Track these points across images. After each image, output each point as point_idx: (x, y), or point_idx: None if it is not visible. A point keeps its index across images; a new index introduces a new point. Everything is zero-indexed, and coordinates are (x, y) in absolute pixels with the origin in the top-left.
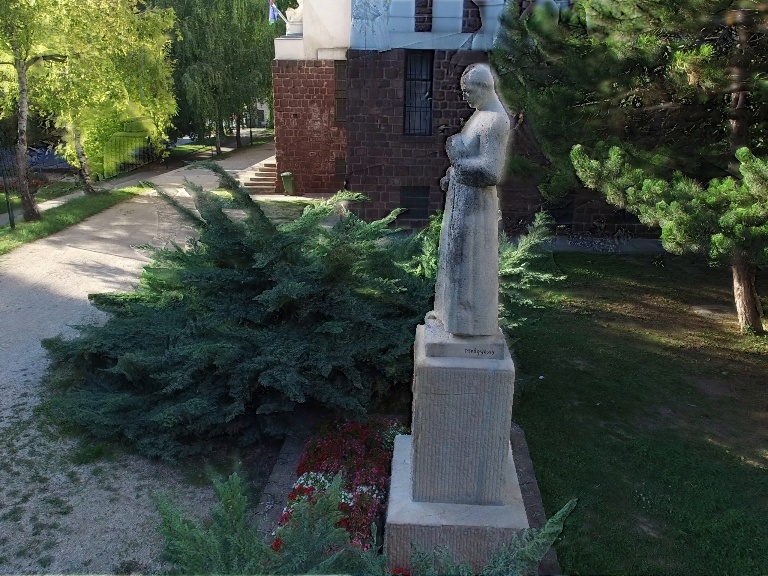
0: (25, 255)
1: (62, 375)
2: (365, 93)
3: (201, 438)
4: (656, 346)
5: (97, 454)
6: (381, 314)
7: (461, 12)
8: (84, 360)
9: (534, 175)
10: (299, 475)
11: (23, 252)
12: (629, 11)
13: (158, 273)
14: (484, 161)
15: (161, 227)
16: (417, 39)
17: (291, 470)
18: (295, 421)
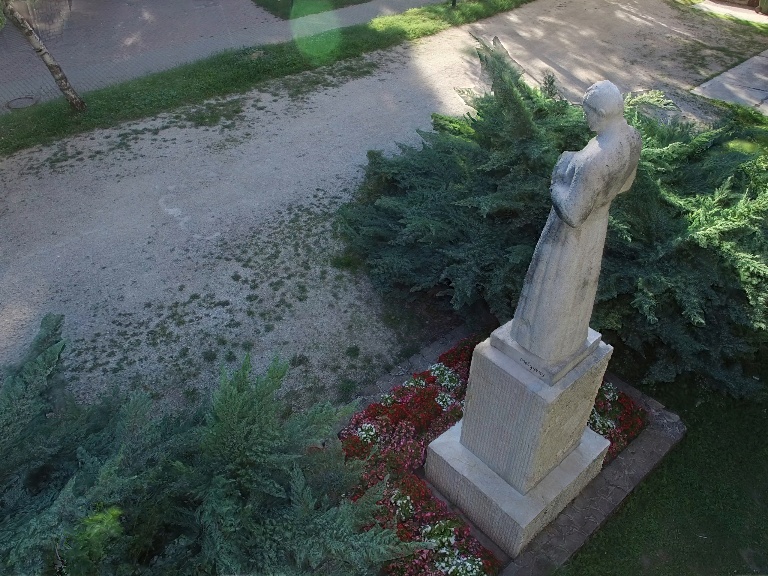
0: (444, 41)
1: (364, 187)
2: None
3: None
4: None
5: (347, 264)
6: (612, 249)
7: None
8: (383, 181)
9: None
10: (438, 361)
11: (444, 37)
12: None
13: (427, 138)
14: (565, 200)
15: (482, 77)
16: None
17: None
18: (481, 311)
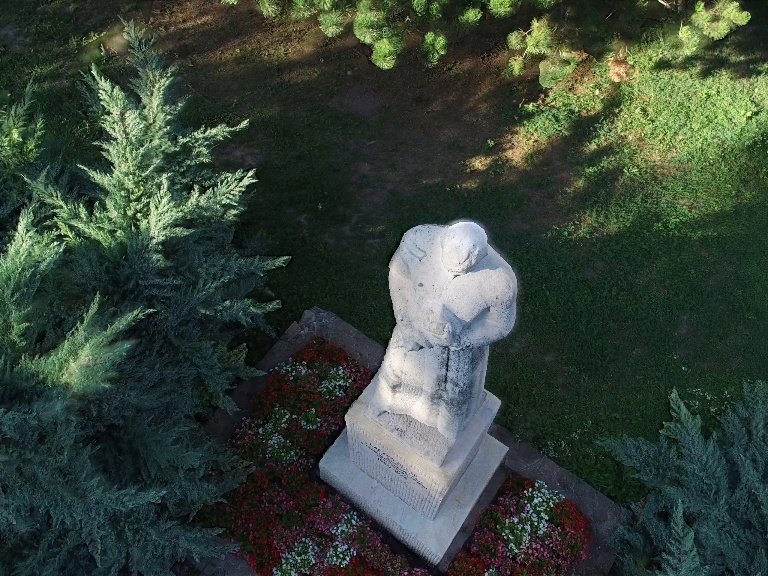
0: None
1: None
2: None
3: None
4: (267, 70)
5: None
6: (113, 340)
7: None
8: None
9: None
10: None
11: None
12: None
13: None
14: (505, 329)
15: None
16: None
17: (243, 575)
18: None
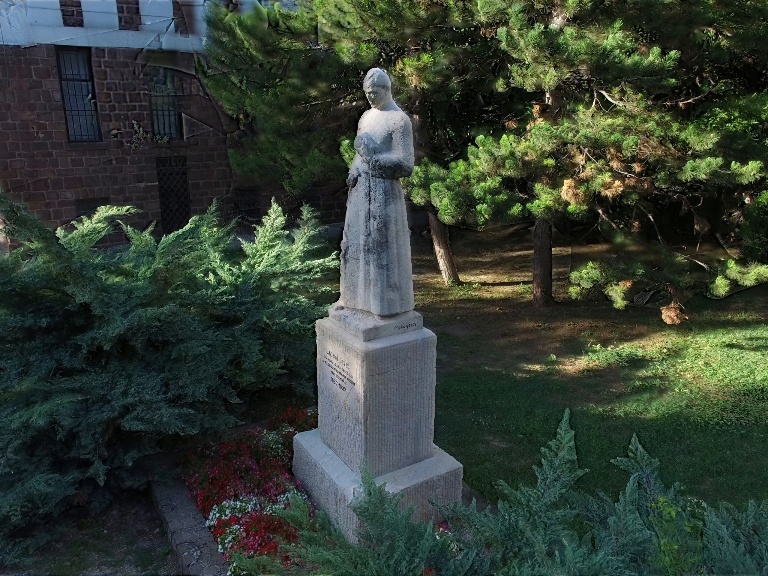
0: None
1: None
2: (11, 95)
3: (42, 523)
4: None
5: None
6: None
7: (115, 7)
8: None
9: (271, 173)
10: (207, 511)
11: None
12: (354, 21)
13: None
14: (402, 155)
15: None
16: (68, 34)
17: (188, 512)
18: (153, 464)
